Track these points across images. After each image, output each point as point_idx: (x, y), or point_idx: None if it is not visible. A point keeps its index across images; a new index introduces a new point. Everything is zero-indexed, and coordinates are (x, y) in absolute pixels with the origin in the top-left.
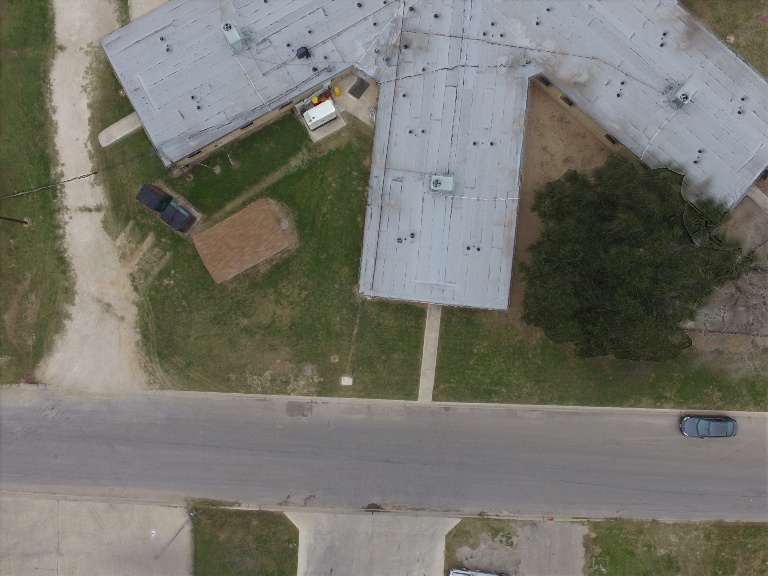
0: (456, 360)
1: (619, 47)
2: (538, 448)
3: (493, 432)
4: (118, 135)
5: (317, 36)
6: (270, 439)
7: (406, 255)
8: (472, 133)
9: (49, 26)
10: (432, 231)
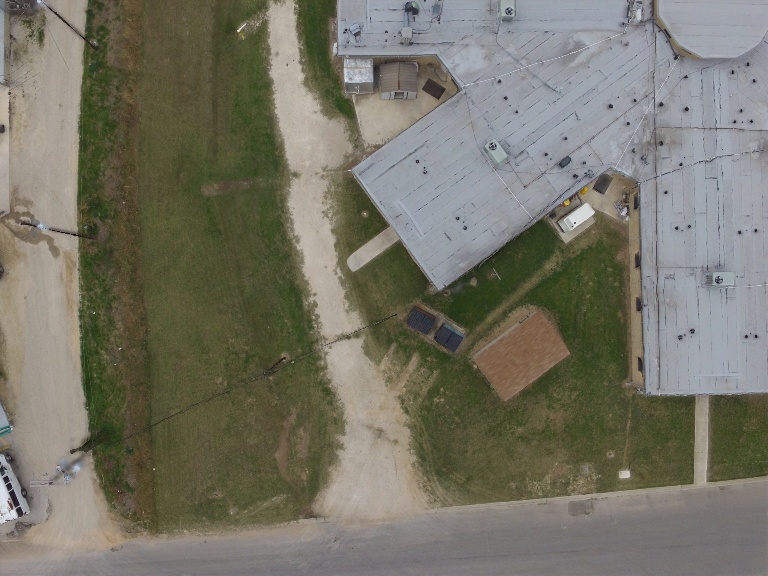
0: (727, 440)
1: None
2: None
3: (767, 504)
4: (367, 258)
5: (572, 141)
6: (556, 541)
7: (687, 350)
8: (736, 222)
9: (280, 154)
10: (711, 324)
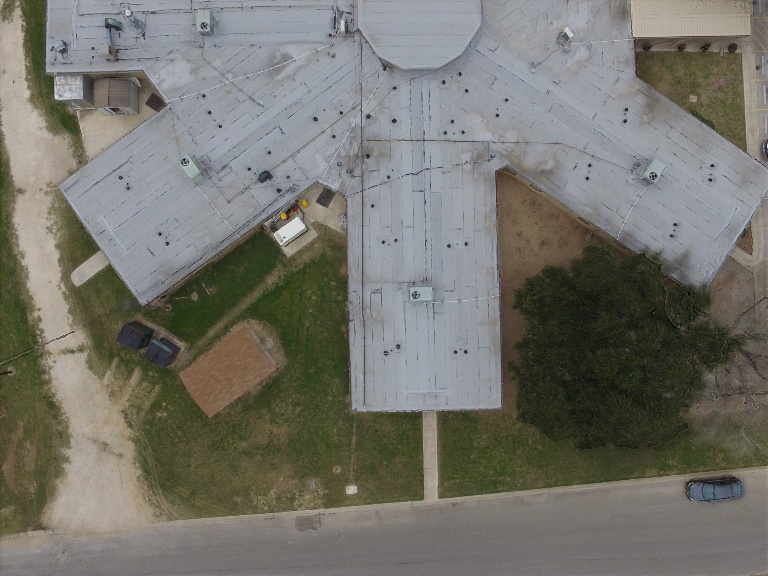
0: (457, 456)
1: (583, 129)
2: (548, 531)
3: (502, 521)
4: (90, 273)
5: (277, 155)
6: (283, 556)
7: (394, 366)
8: (445, 235)
9: (5, 170)
10: (417, 340)
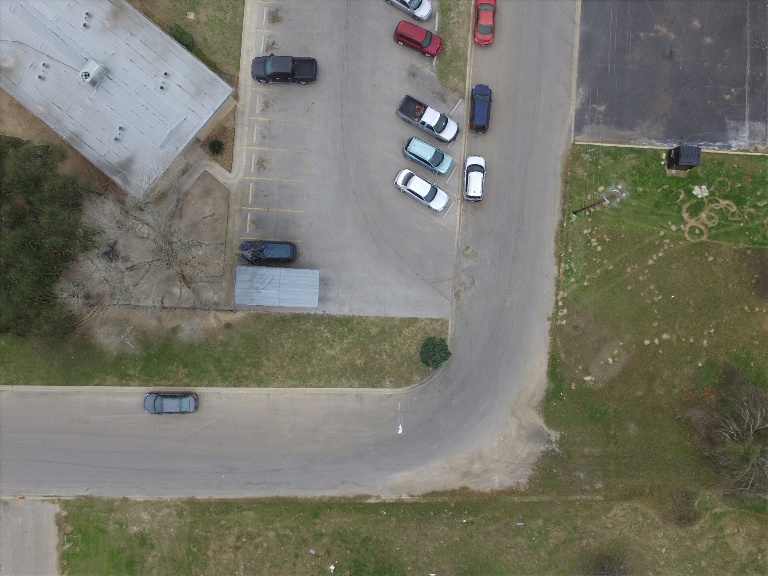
0: None
1: (39, 29)
2: (7, 428)
3: None
4: None
5: None
6: None
7: None
8: None
9: None
10: None
